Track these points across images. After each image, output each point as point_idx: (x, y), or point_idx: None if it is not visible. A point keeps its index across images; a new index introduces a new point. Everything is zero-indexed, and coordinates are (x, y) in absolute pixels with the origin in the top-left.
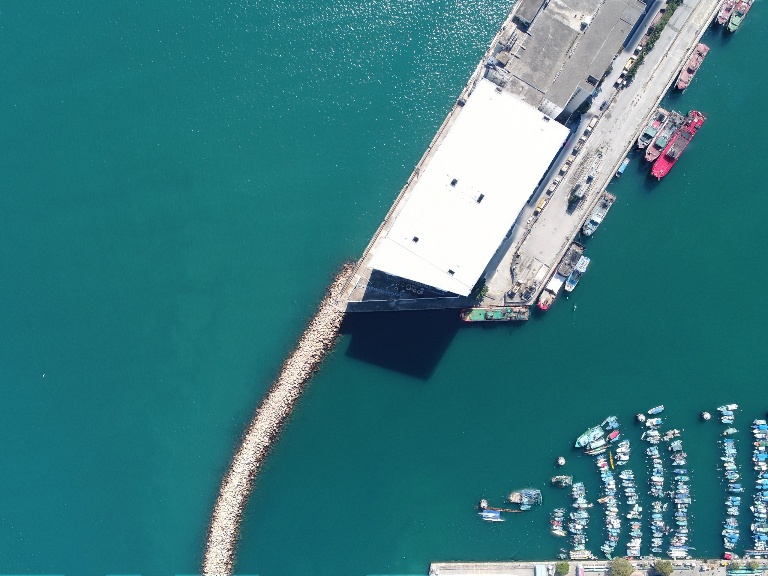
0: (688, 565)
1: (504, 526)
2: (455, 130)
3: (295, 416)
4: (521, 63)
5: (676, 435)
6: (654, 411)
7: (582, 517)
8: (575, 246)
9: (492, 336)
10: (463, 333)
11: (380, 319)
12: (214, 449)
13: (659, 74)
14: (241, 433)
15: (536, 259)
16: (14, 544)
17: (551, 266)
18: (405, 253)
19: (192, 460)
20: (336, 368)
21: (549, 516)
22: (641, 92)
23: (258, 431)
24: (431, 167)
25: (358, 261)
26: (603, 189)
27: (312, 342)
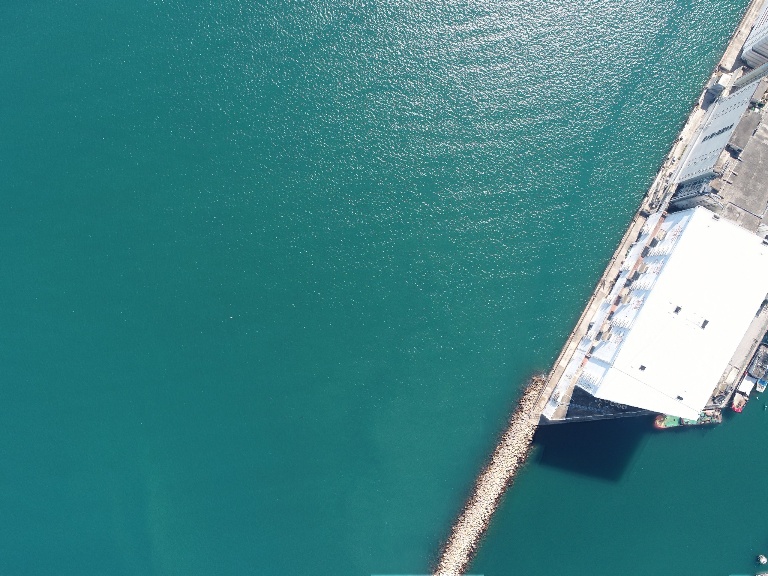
0: None
1: None
2: (674, 258)
3: (491, 531)
4: (733, 188)
5: None
6: None
7: None
8: (763, 347)
9: (685, 440)
10: (656, 438)
11: (573, 430)
12: (411, 570)
13: None
14: (437, 551)
15: None
16: None
17: (742, 368)
18: (632, 381)
19: None
20: (529, 480)
21: None
22: None
23: (457, 550)
24: (653, 295)
25: (549, 374)
26: None
27: (507, 457)
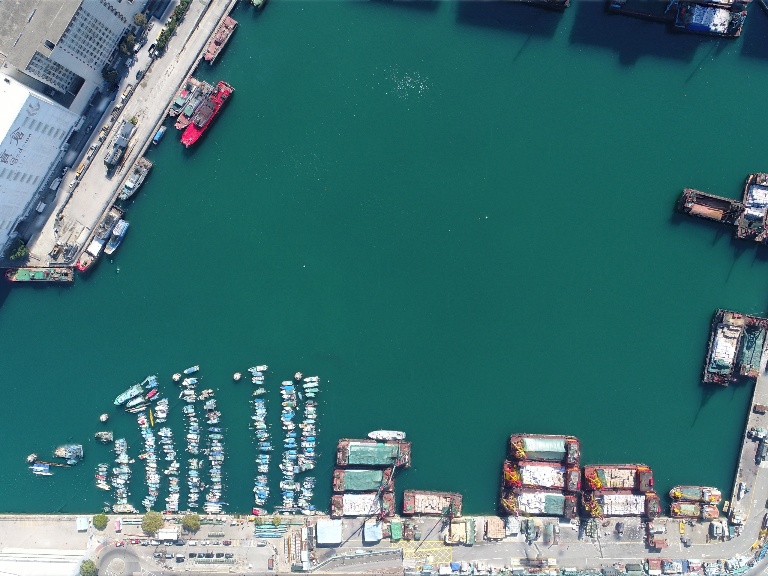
0: (219, 520)
1: (52, 480)
2: None
3: None
4: None
5: (211, 394)
6: (187, 371)
7: (122, 472)
8: (115, 210)
9: (42, 296)
10: (14, 293)
11: None
12: None
13: (191, 45)
14: None
15: (78, 222)
16: None
17: (91, 229)
18: None
19: None
20: None
21: (95, 471)
22: (174, 62)
23: None
24: None
25: None
26: (140, 156)
27: None
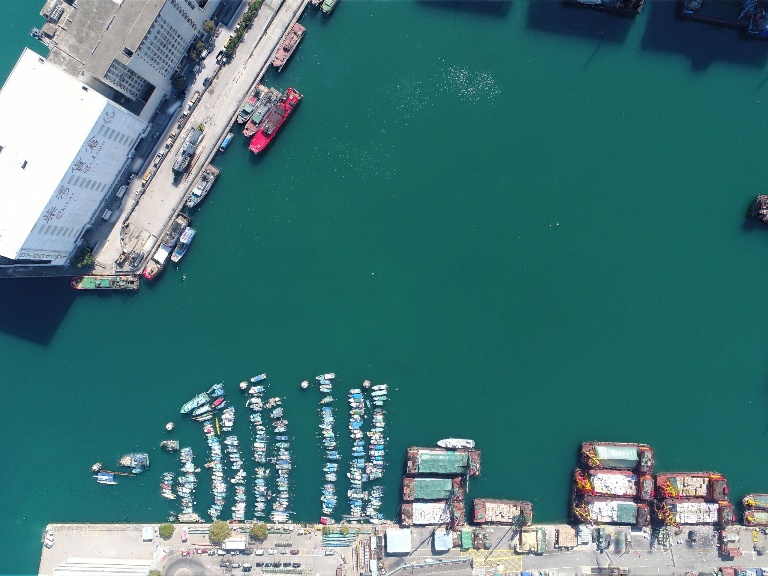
0: (286, 529)
1: (117, 489)
2: (2, 98)
3: None
4: (68, 35)
5: (278, 403)
6: (255, 379)
7: (188, 481)
8: (181, 218)
9: (107, 304)
10: (79, 301)
11: None
12: None
13: (259, 52)
14: None
15: (145, 230)
16: None
17: (157, 237)
18: None
19: None
20: None
21: (160, 480)
22: (242, 69)
23: None
24: None
25: None
26: (207, 163)
27: None
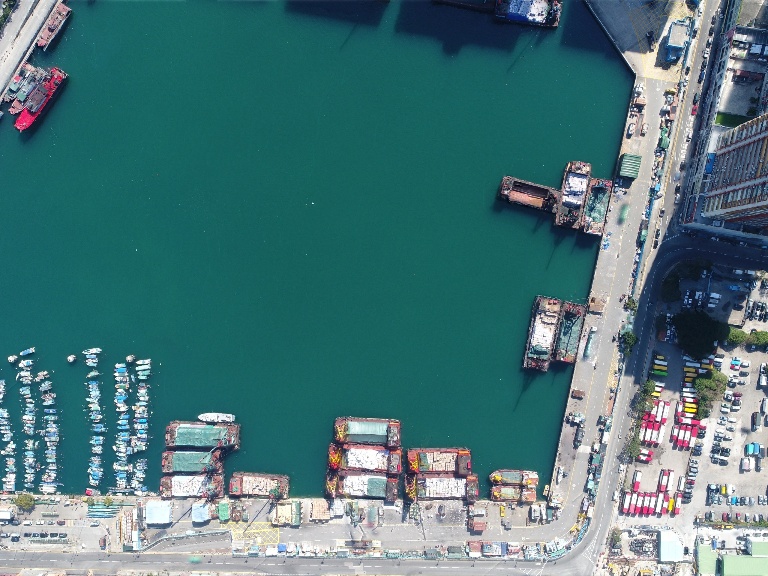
0: (53, 500)
1: None
2: None
3: None
4: None
5: (46, 376)
6: (23, 353)
7: None
8: None
9: None
10: None
11: None
12: None
13: (26, 32)
14: None
15: None
16: None
17: None
18: None
19: None
20: None
21: None
22: (10, 48)
23: None
24: None
25: None
26: None
27: None
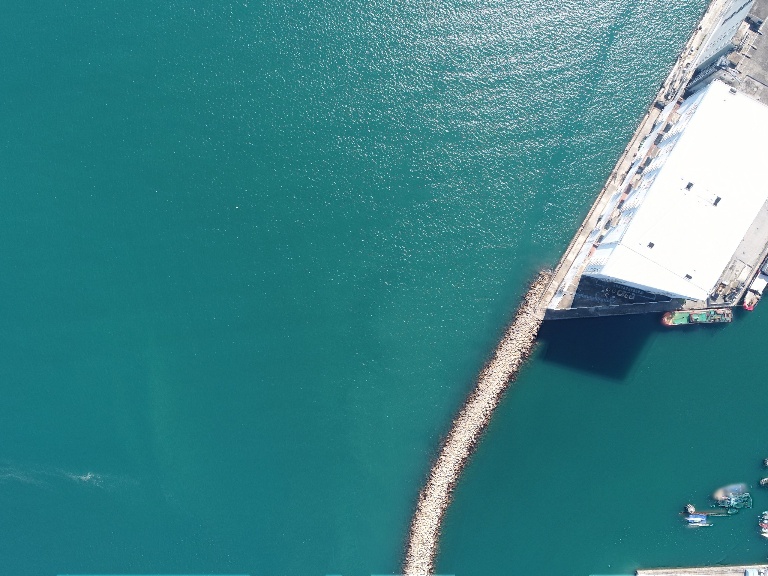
0: None
1: (711, 531)
2: (688, 133)
3: (492, 426)
4: (752, 63)
5: None
6: None
7: None
8: None
9: (693, 339)
10: (664, 337)
11: (579, 326)
12: (410, 463)
13: None
14: (437, 446)
15: (738, 260)
16: (222, 566)
17: (755, 266)
18: (639, 259)
19: (389, 475)
20: (532, 377)
21: (757, 519)
22: None
23: (457, 443)
24: (664, 171)
25: (556, 268)
26: None
27: (511, 351)
